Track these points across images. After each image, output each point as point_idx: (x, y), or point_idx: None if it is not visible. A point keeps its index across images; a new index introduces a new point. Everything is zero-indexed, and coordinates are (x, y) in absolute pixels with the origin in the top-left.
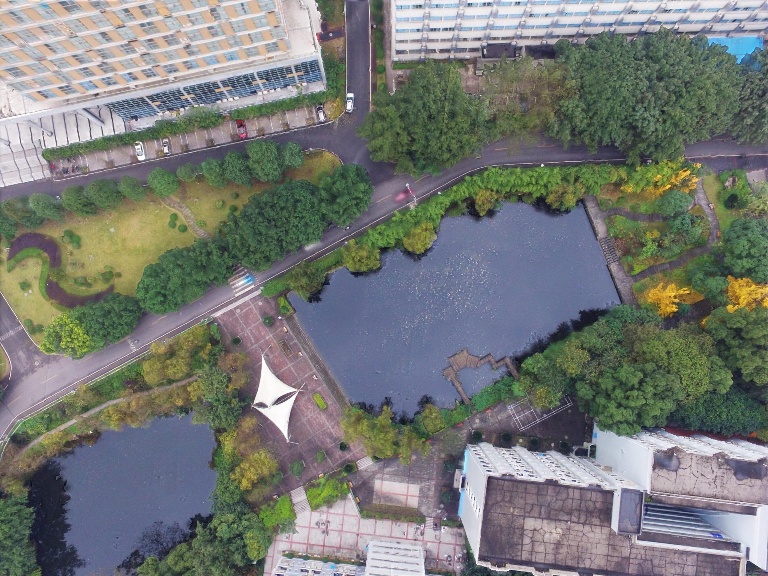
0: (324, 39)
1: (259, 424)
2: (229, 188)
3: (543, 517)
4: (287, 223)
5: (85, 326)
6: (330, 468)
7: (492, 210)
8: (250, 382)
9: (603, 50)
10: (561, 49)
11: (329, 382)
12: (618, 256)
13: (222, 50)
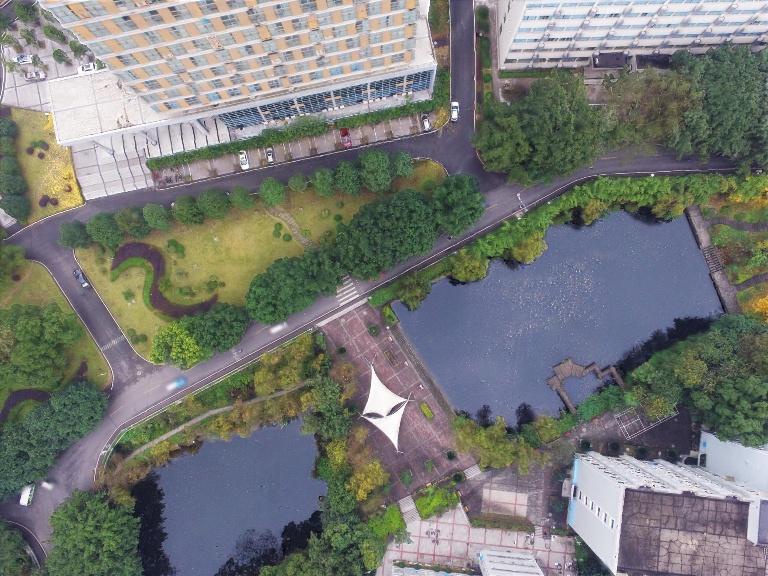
0: None
1: None
2: (334, 197)
3: (679, 528)
4: (402, 234)
5: (195, 337)
6: (437, 477)
7: (595, 219)
8: (356, 392)
9: (728, 61)
10: (681, 59)
11: (435, 391)
12: (721, 265)
13: (350, 61)
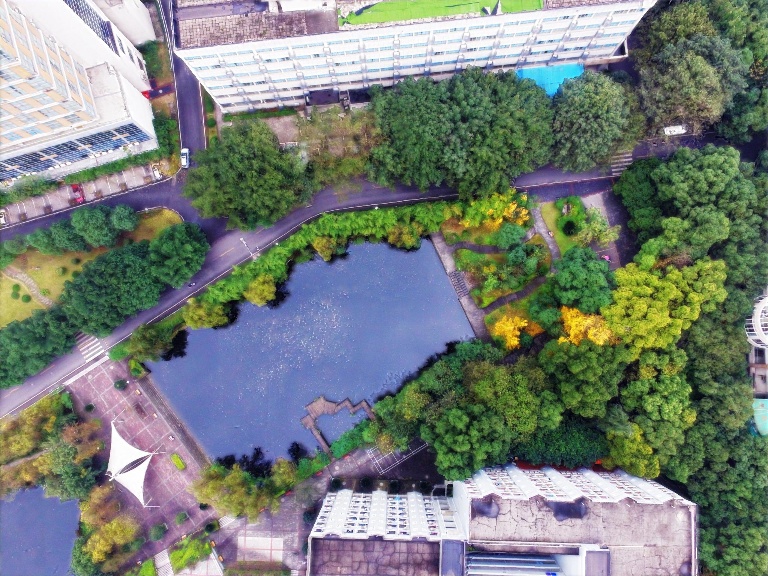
0: (154, 96)
1: (119, 490)
2: (70, 254)
3: (371, 574)
4: (118, 289)
5: None
6: (193, 528)
7: None
8: (107, 448)
9: (408, 95)
10: (374, 94)
11: (187, 441)
12: (469, 289)
13: (19, 127)
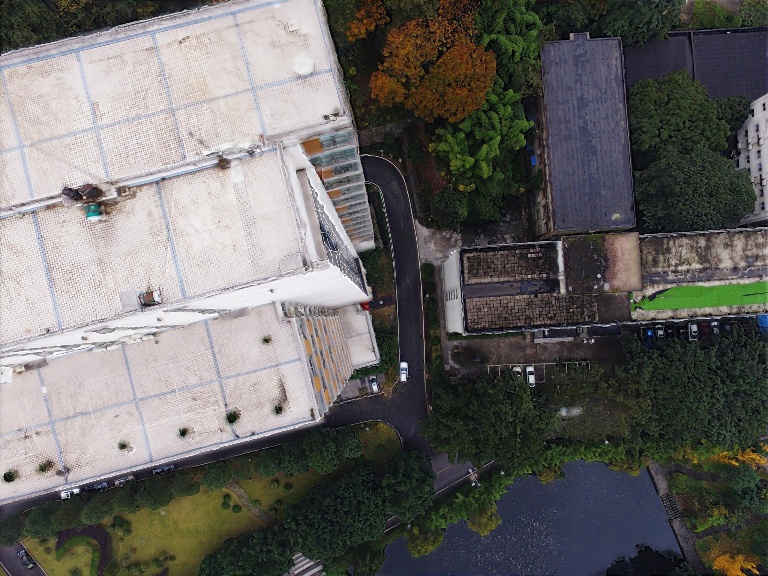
0: (374, 307)
1: None
2: None
3: None
4: (351, 526)
5: None
6: None
7: None
8: None
9: (676, 362)
10: (629, 347)
11: None
12: (680, 511)
13: None
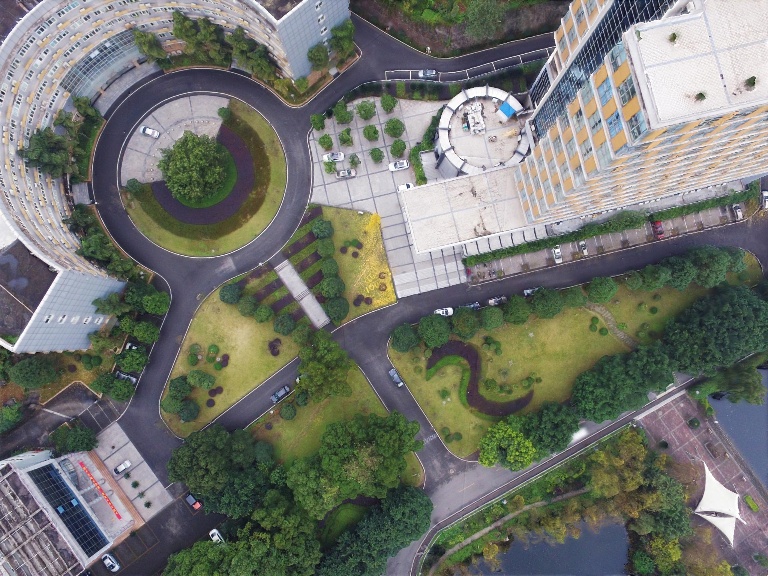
0: None
1: None
2: None
3: None
4: (748, 332)
5: (532, 439)
6: (765, 571)
7: None
8: None
9: None
10: None
11: (755, 482)
12: None
13: (735, 172)
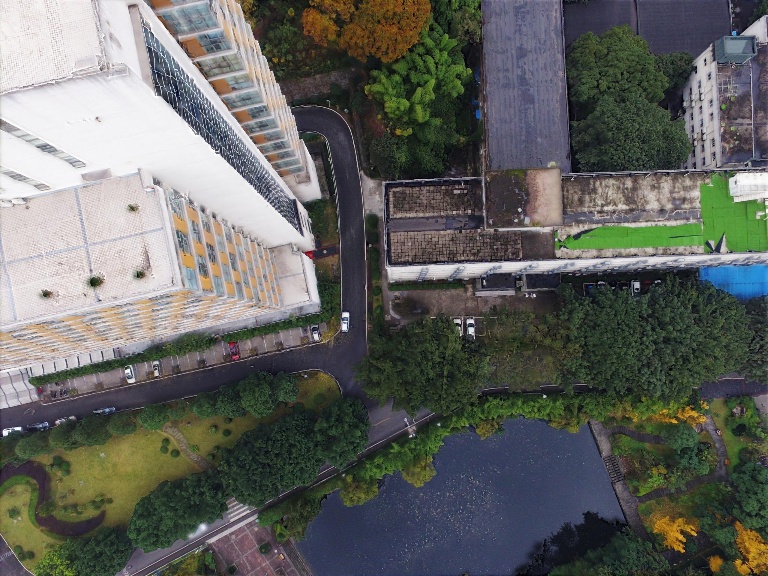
0: (318, 256)
1: None
2: None
3: None
4: (282, 469)
5: (76, 567)
6: None
7: None
8: None
9: (607, 309)
10: (563, 296)
11: None
12: (623, 474)
13: (212, 321)
